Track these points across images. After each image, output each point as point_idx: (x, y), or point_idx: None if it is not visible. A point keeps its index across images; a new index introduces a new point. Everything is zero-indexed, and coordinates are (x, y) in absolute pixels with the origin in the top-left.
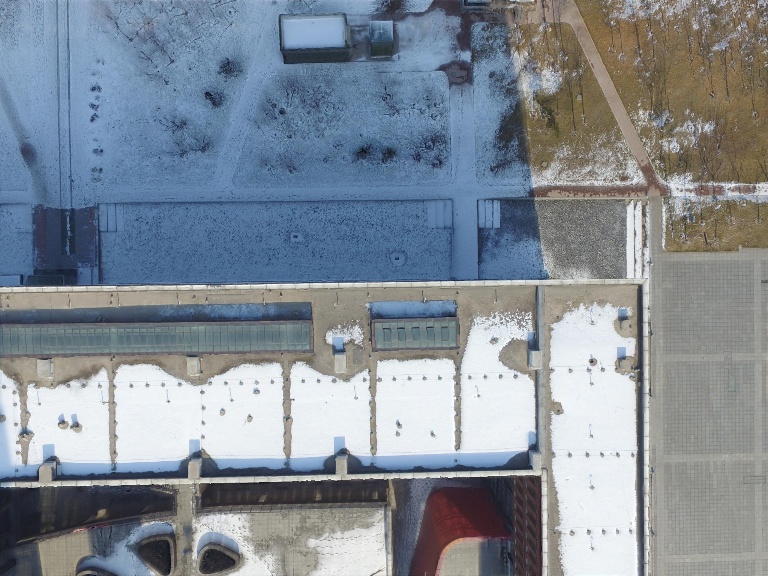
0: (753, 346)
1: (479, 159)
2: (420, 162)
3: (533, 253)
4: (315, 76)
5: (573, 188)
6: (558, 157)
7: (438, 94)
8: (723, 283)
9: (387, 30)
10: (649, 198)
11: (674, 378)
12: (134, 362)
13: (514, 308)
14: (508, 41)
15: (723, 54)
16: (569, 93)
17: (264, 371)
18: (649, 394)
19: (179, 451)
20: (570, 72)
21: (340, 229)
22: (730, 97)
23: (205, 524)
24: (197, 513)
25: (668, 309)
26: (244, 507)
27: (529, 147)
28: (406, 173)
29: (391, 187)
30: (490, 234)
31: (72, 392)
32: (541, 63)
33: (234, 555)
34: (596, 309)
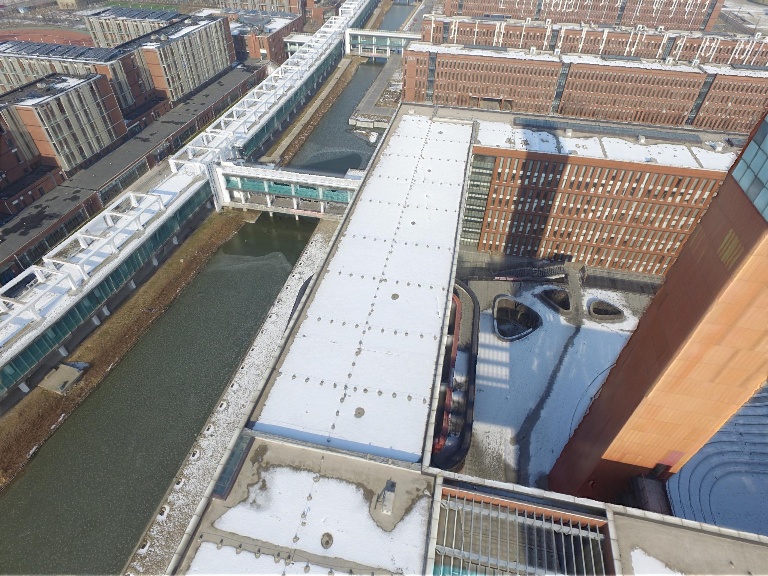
0: None
1: None
2: None
3: None
4: None
5: None
6: None
7: None
8: None
9: None
10: None
11: None
12: (610, 137)
13: None
14: None
15: None
16: None
17: (677, 146)
18: None
19: (640, 159)
20: None
21: None
22: None
23: (591, 293)
24: (584, 287)
25: None
26: None
27: None
28: None
29: None
30: None
31: (581, 140)
32: None
33: None
34: None
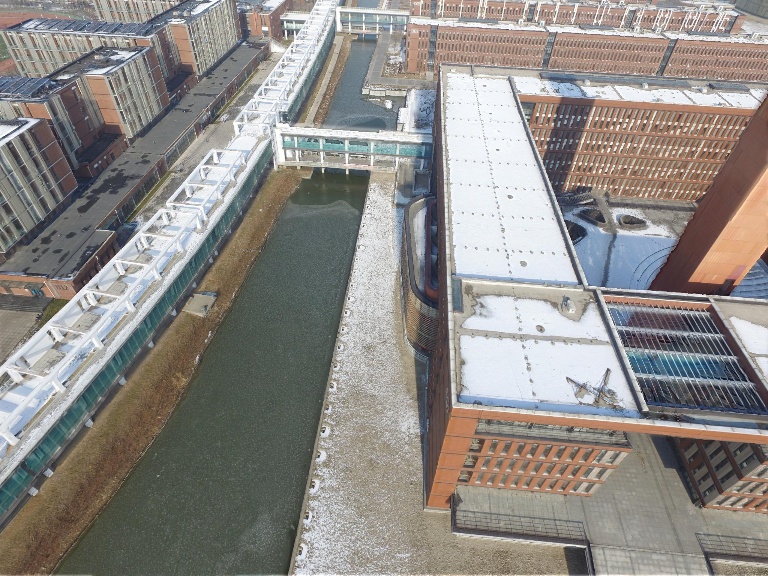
0: None
1: None
2: None
3: None
4: None
5: None
6: None
7: None
8: None
9: None
10: None
11: None
12: (620, 85)
13: (763, 88)
14: None
15: None
16: None
17: None
18: None
19: (649, 100)
20: None
21: None
22: None
23: None
24: (610, 207)
25: None
26: (638, 207)
27: None
28: None
29: None
30: None
31: None
32: None
33: (642, 219)
34: None
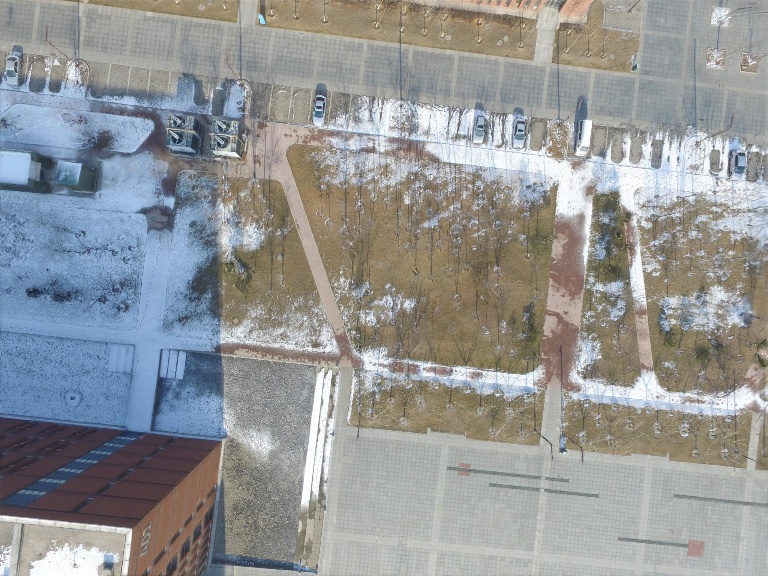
0: (430, 534)
1: (168, 308)
2: (105, 304)
3: (214, 410)
4: (11, 204)
5: (262, 349)
6: (250, 315)
7: (135, 237)
8: (406, 465)
9: (74, 173)
10: (340, 368)
11: (343, 558)
12: None
13: None
14: (214, 192)
15: (431, 232)
16: (270, 252)
17: None
18: (316, 571)
19: None
20: (274, 231)
21: (17, 361)
22: (433, 277)
23: None
24: None
25: (346, 485)
26: None
27: (222, 301)
28: (90, 313)
29: (73, 326)
30: (172, 385)
31: None
32: (245, 218)
33: None
34: (81, 552)
